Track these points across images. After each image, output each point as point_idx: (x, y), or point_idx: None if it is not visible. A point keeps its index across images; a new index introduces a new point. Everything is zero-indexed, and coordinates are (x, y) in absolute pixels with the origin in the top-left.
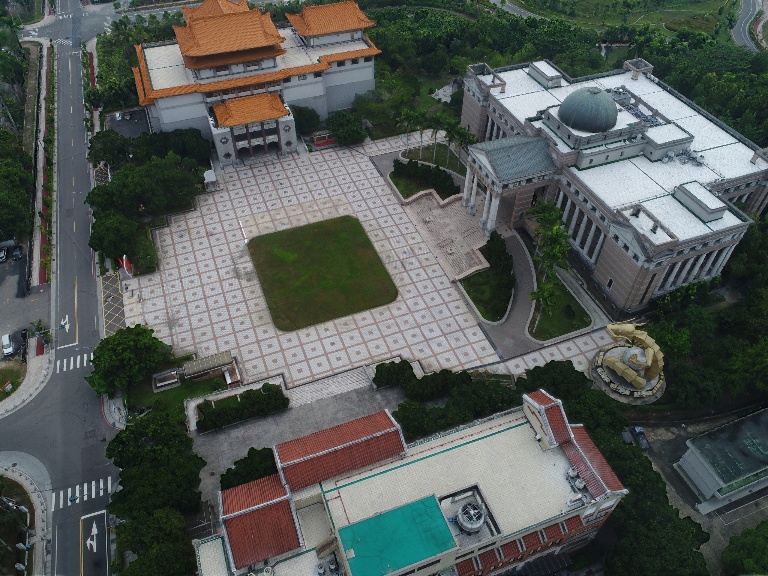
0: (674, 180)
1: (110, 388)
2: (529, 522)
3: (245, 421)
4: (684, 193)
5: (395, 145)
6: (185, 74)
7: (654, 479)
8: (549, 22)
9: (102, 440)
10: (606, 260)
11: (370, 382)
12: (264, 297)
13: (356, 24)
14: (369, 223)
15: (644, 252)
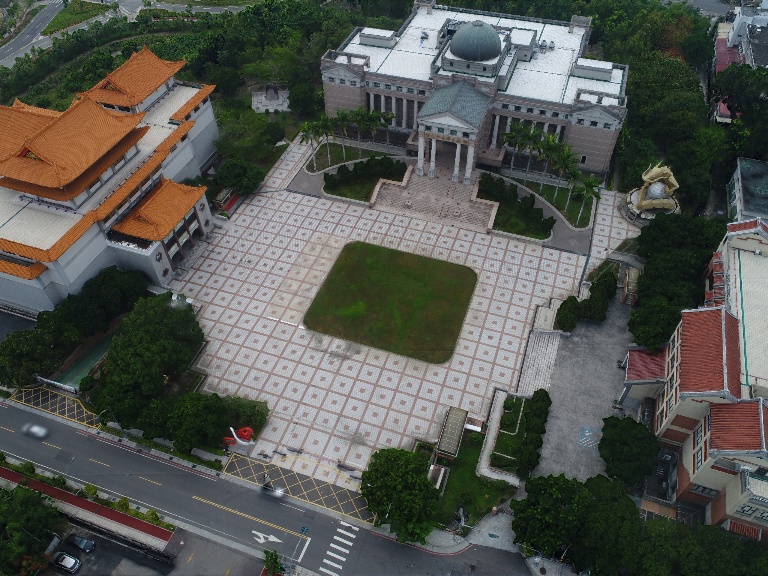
0: (557, 66)
1: (428, 524)
2: None
3: None
4: (583, 69)
5: (290, 168)
6: (48, 214)
7: None
8: (266, 5)
9: (472, 569)
10: (574, 144)
11: (558, 335)
12: (392, 353)
13: (168, 70)
14: (371, 238)
15: (617, 117)
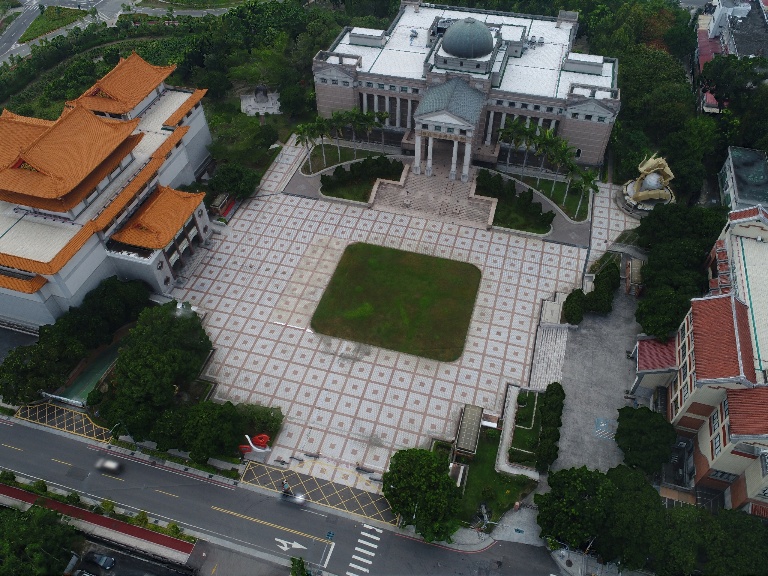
0: (548, 61)
1: (453, 522)
2: None
3: None
4: (574, 63)
5: (285, 170)
6: (45, 226)
7: None
8: (249, 7)
9: (498, 565)
10: (569, 138)
11: (566, 328)
12: (402, 353)
13: (158, 75)
14: (372, 238)
15: (611, 110)
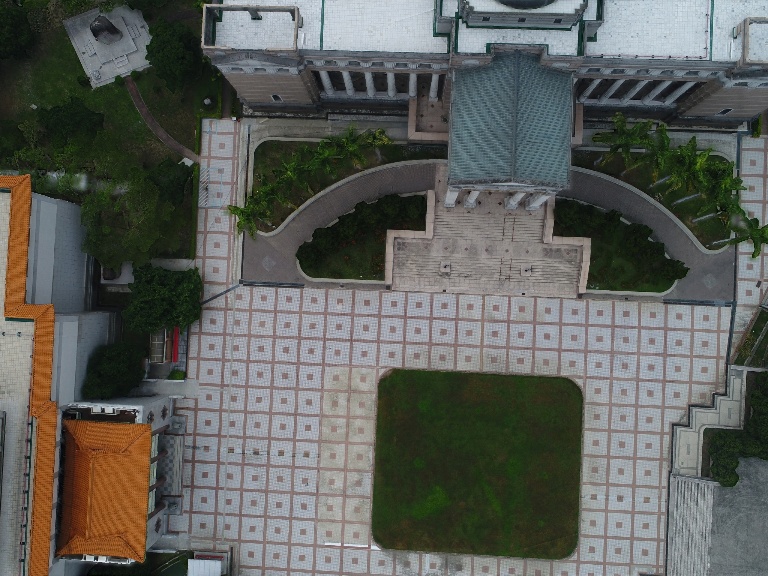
0: None
1: None
2: None
3: None
4: None
5: (225, 226)
6: None
7: None
8: None
9: None
10: None
11: (712, 485)
12: (502, 557)
13: None
14: (411, 357)
15: None
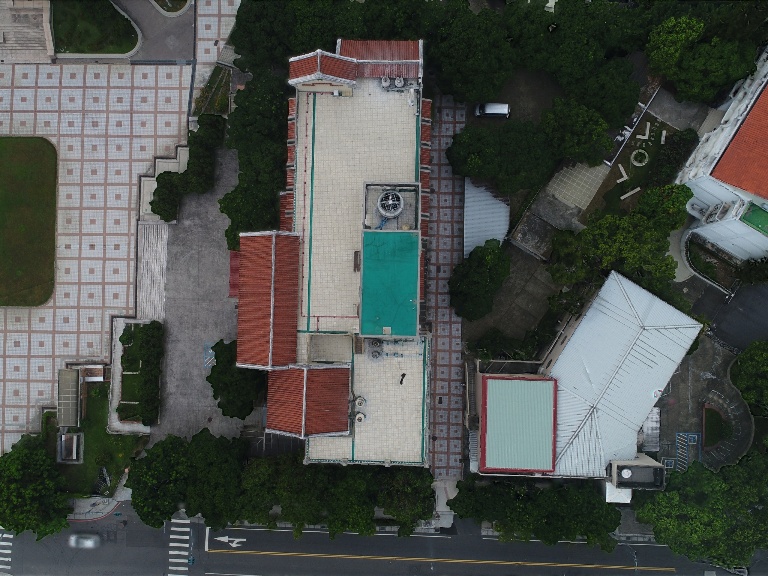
0: None
1: (63, 513)
2: (412, 151)
3: (161, 374)
4: None
5: None
6: None
7: (407, 2)
8: None
9: (124, 525)
10: None
11: (165, 225)
12: None
13: None
14: None
15: None
